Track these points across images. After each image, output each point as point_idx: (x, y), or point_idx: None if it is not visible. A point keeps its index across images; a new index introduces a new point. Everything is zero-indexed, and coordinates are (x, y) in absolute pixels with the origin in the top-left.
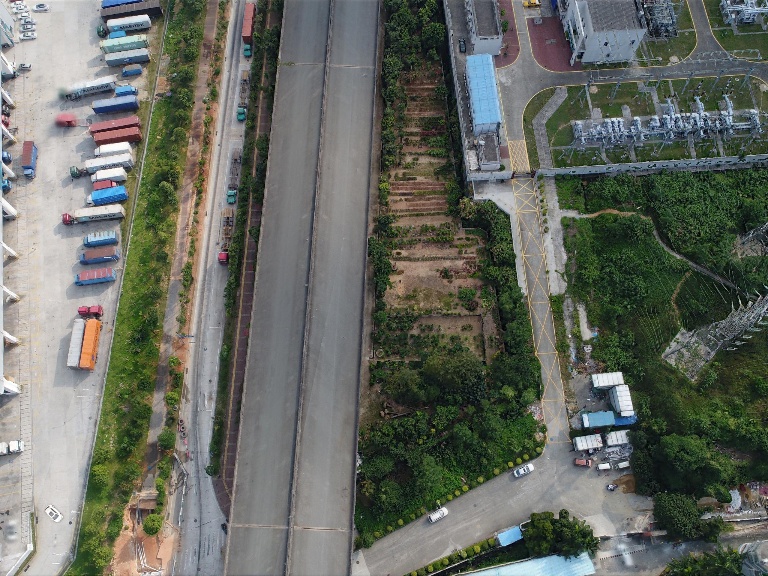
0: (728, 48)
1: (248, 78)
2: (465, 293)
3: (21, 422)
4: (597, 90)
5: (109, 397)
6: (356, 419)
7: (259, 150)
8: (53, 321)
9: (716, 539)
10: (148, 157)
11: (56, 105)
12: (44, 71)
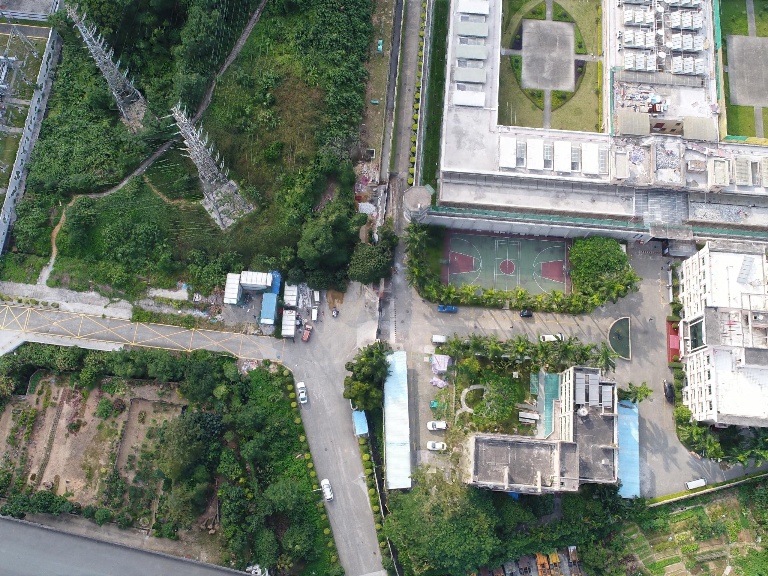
0: None
1: None
2: (102, 411)
3: None
4: None
5: None
6: (209, 568)
7: None
8: None
9: (397, 237)
10: None
11: None
12: None
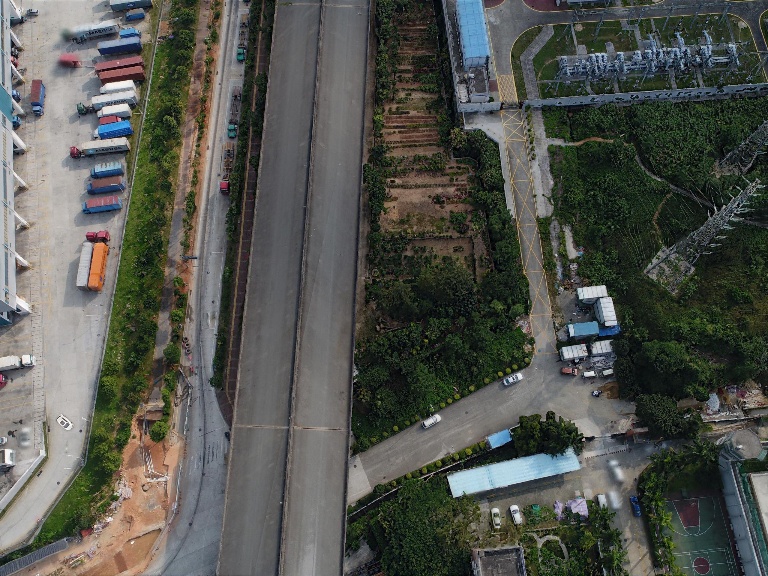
0: None
1: (247, 21)
2: (456, 217)
3: (33, 339)
4: (582, 28)
5: (116, 316)
6: (353, 329)
7: (258, 86)
8: (62, 247)
9: (695, 436)
10: (152, 95)
11: (63, 48)
12: (51, 16)
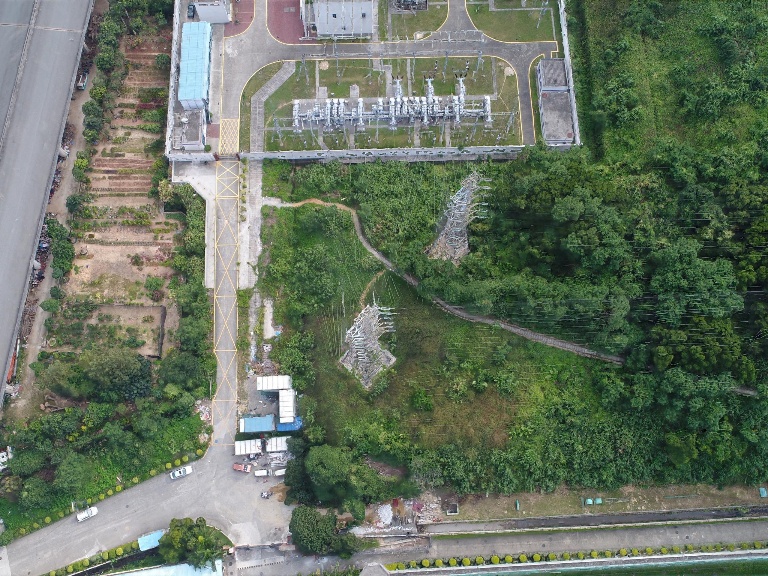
0: (479, 25)
1: None
2: (150, 282)
3: None
4: (328, 66)
5: None
6: None
7: None
8: None
9: (350, 556)
10: None
11: None
12: None
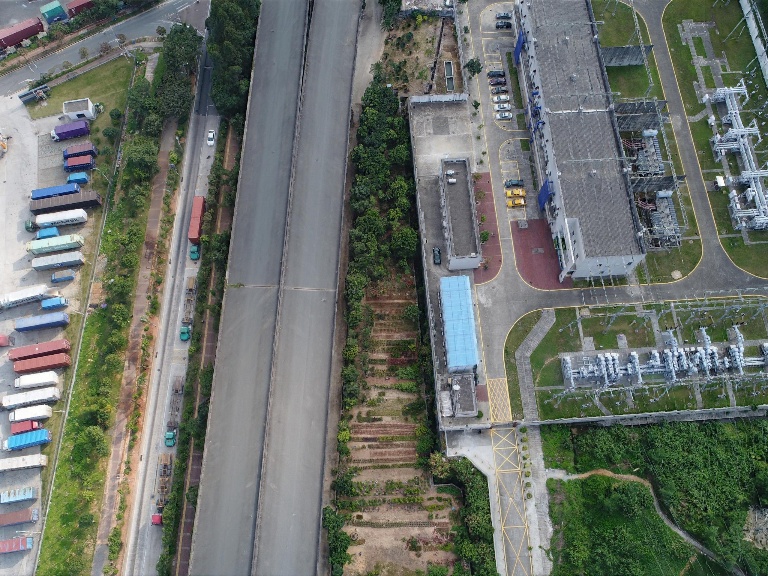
0: (738, 261)
1: (194, 287)
2: (435, 573)
3: None
4: None
5: None
6: None
7: (202, 387)
8: None
9: None
10: (77, 385)
11: None
12: None
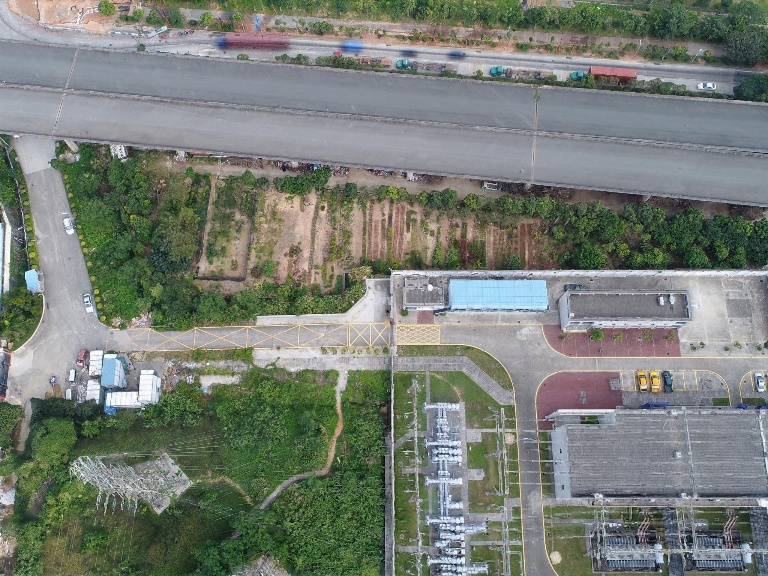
0: None
1: (543, 76)
2: (269, 264)
3: None
4: (509, 443)
5: None
6: (146, 144)
7: None
8: None
9: None
10: None
11: None
12: None
